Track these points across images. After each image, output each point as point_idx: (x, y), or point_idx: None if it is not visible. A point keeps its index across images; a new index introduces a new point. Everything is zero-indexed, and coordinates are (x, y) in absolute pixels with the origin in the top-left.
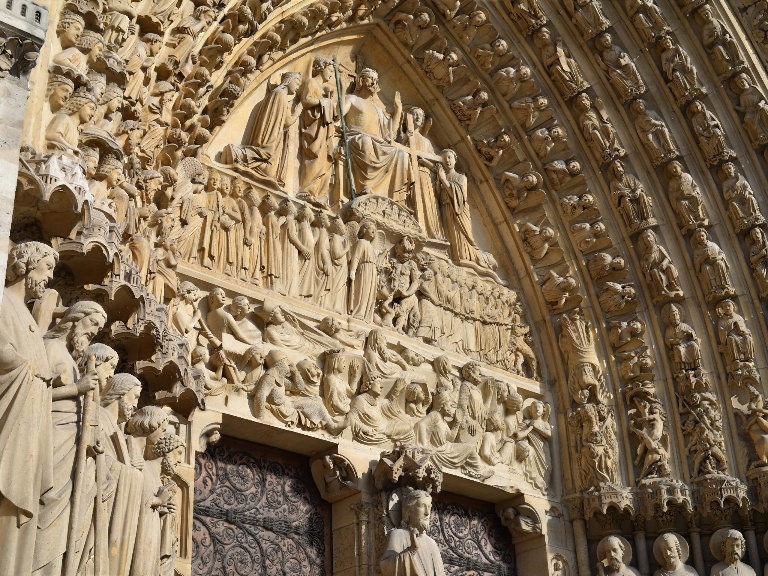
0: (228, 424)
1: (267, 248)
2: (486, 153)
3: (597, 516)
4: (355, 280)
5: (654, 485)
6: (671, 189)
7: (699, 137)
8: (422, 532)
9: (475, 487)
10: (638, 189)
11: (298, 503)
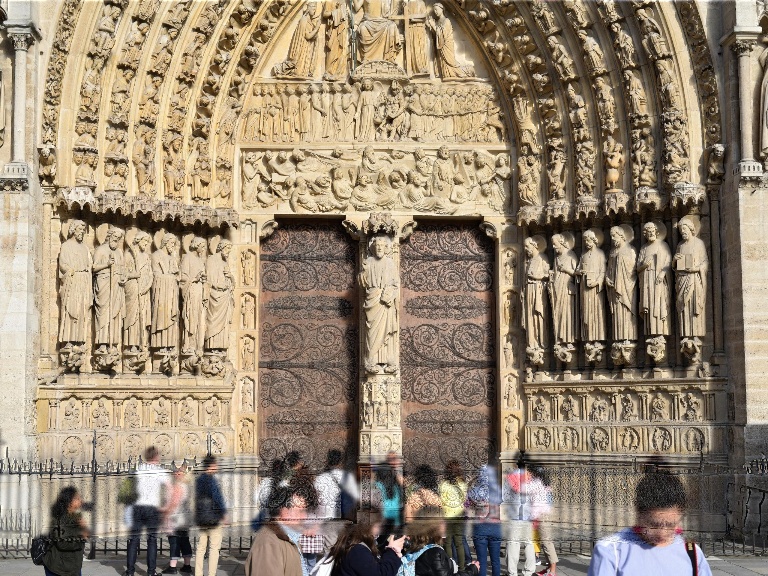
0: None
1: (300, 117)
2: (458, 1)
3: (532, 223)
4: None
5: None
6: None
7: None
8: (381, 258)
9: (452, 217)
10: (542, 10)
11: (339, 244)
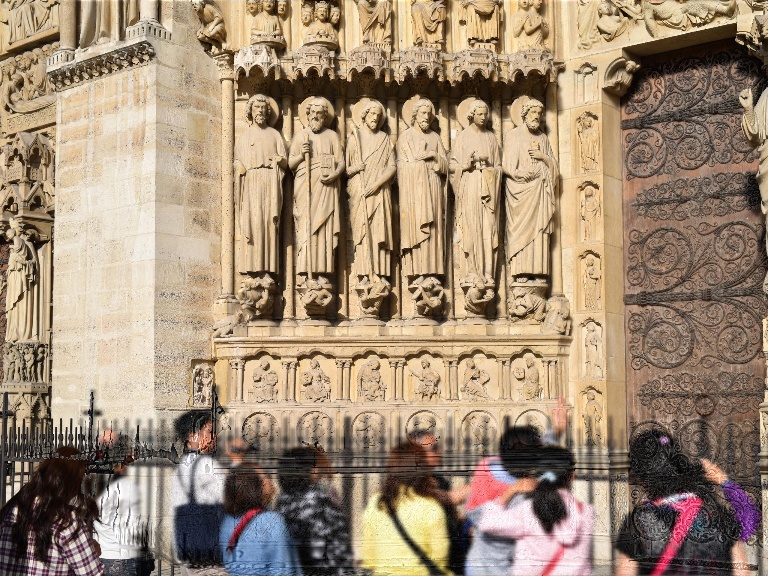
0: (647, 49)
1: None
2: None
3: None
4: None
5: None
6: None
7: None
8: None
9: None
10: None
11: (746, 79)
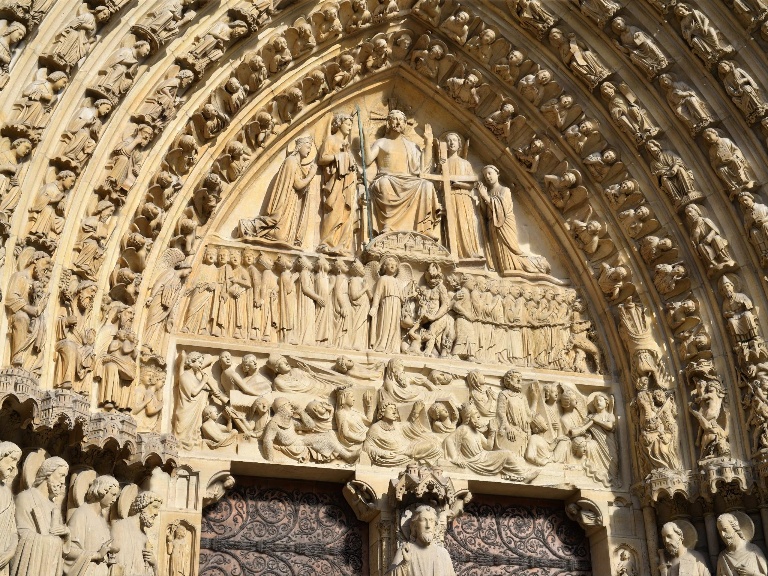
0: (246, 468)
1: (280, 305)
2: (525, 161)
3: (663, 502)
4: (378, 315)
5: (706, 466)
6: (711, 158)
7: (732, 98)
8: (428, 544)
9: (526, 489)
10: (675, 165)
11: (333, 527)
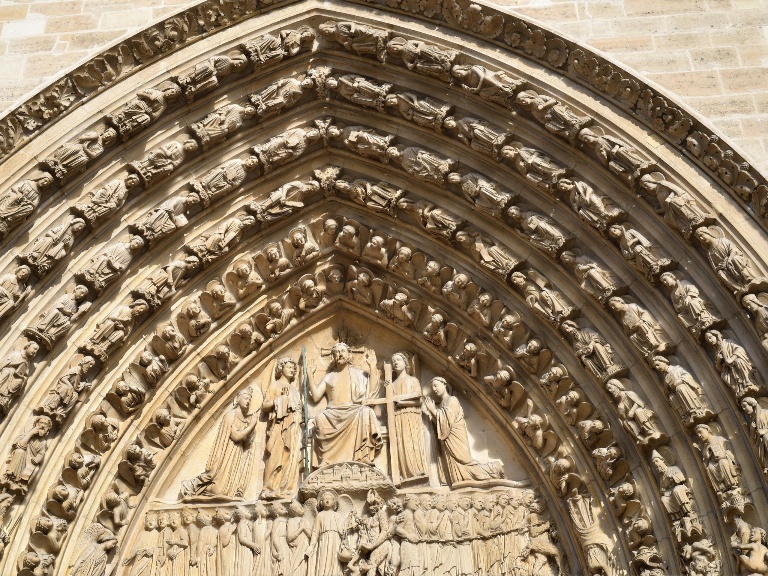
0: None
1: (216, 559)
2: (466, 367)
3: None
4: None
5: None
6: None
7: None
8: None
9: None
10: (590, 342)
11: None
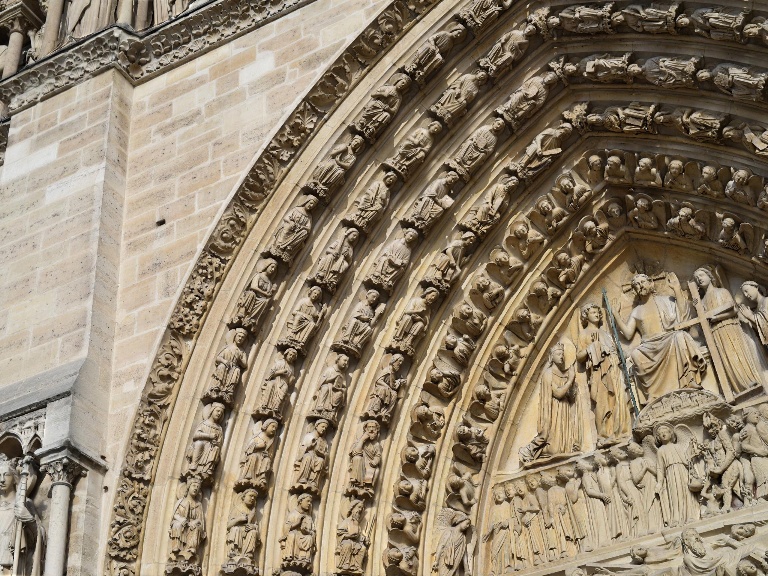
0: None
1: None
2: None
3: None
4: None
5: None
6: None
7: None
8: None
9: None
10: None
11: None
